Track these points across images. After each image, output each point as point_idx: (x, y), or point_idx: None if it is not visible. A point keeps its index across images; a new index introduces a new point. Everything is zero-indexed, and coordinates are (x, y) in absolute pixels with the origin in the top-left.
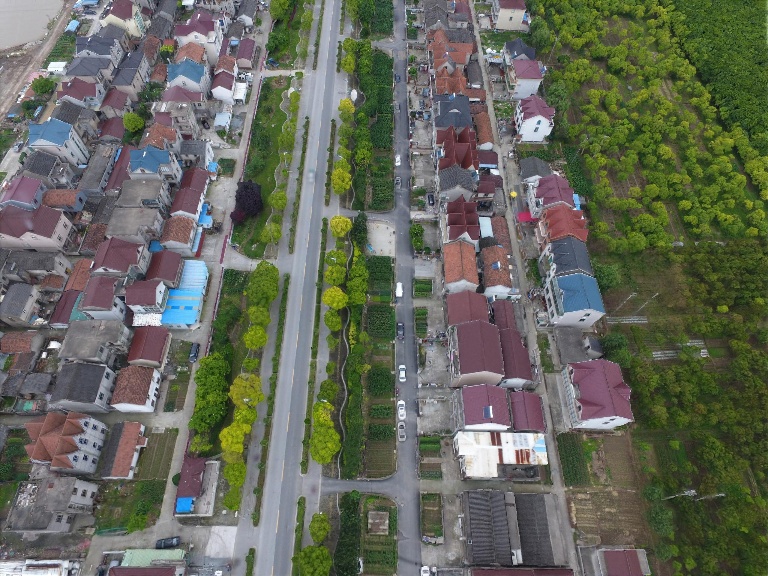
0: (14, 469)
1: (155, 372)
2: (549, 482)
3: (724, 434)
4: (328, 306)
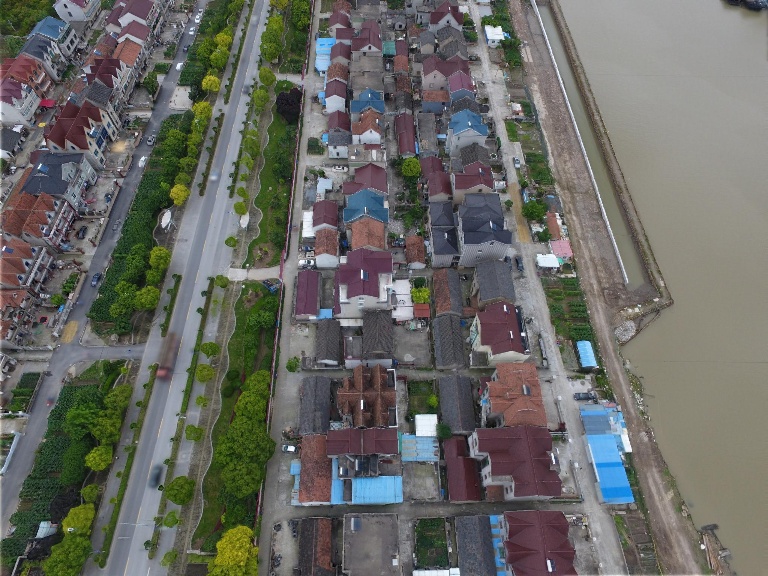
0: None
1: None
2: None
3: None
4: None
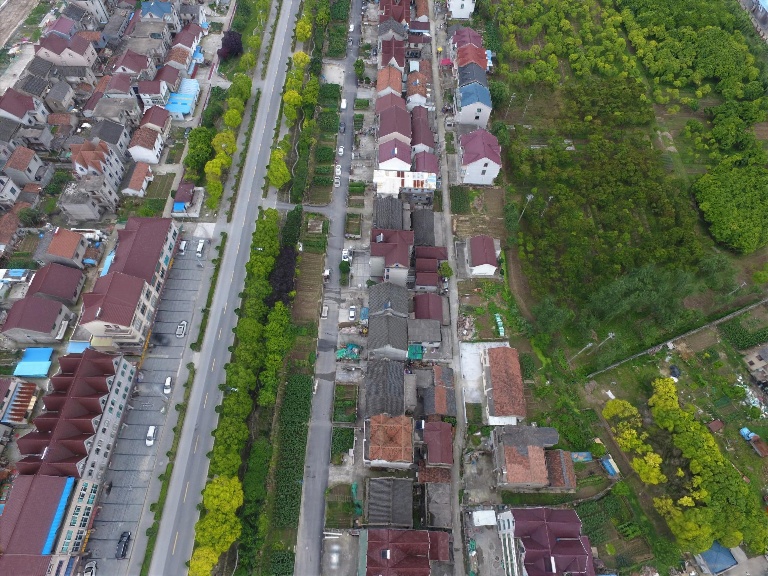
0: (60, 189)
1: (159, 136)
2: (440, 210)
3: (572, 186)
4: None
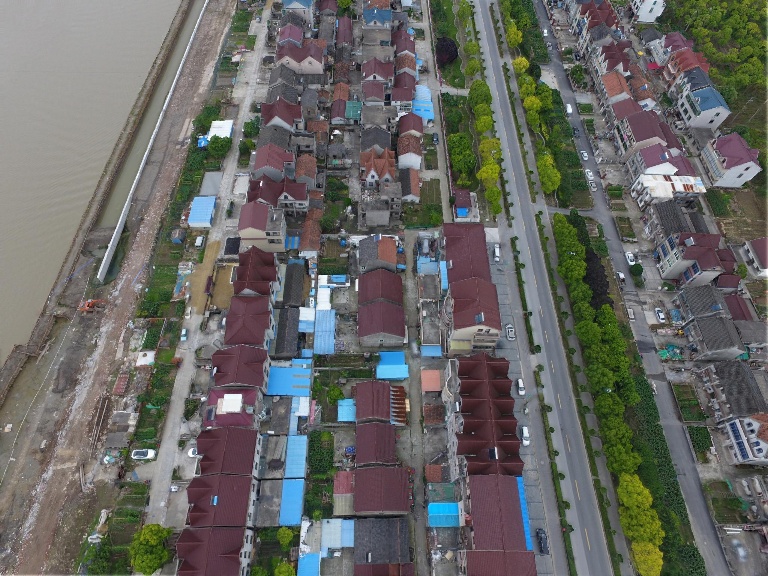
0: None
1: None
2: (702, 213)
3: None
4: (522, 115)
